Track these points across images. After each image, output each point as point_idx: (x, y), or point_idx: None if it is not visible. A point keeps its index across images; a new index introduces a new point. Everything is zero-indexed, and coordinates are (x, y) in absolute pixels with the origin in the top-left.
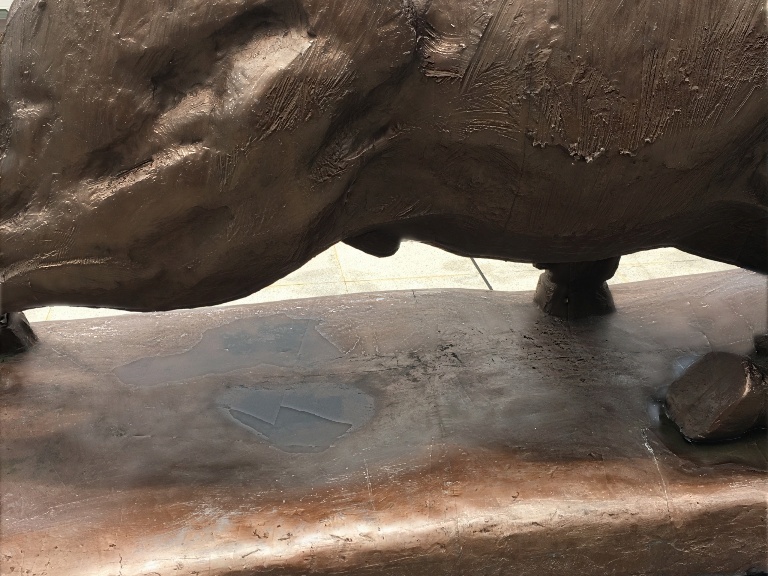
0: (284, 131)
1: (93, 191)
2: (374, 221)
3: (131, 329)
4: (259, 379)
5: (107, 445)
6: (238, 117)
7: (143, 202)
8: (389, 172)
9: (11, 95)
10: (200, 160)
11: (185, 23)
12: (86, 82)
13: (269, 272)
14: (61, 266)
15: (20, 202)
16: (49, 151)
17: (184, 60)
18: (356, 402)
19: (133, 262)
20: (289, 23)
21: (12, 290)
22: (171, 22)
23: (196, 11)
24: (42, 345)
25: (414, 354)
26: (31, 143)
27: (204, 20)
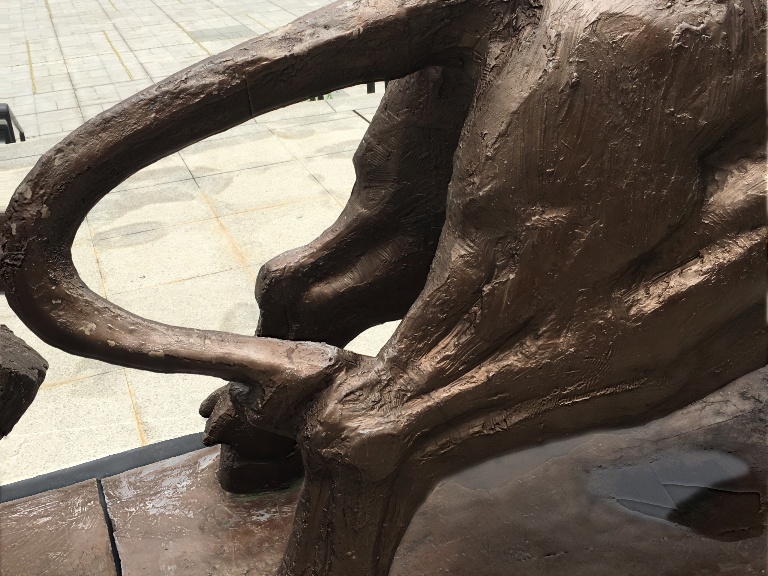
0: None
1: (631, 304)
2: None
3: None
4: (611, 455)
5: (526, 575)
6: None
7: (696, 308)
8: None
9: (522, 200)
10: (766, 249)
11: (749, 87)
12: (635, 174)
13: None
14: (589, 399)
15: (526, 328)
16: (577, 263)
17: (736, 131)
18: (736, 463)
19: (667, 378)
20: None
21: (516, 435)
22: (732, 88)
23: (761, 71)
24: None
25: (746, 394)
26: (554, 257)
27: None
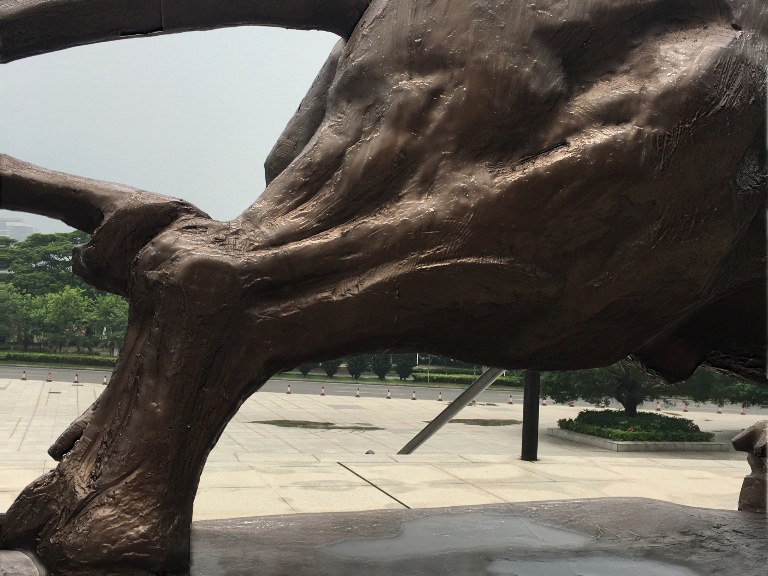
0: (732, 110)
1: (495, 174)
2: (757, 274)
3: (301, 520)
4: (522, 553)
5: None
6: (684, 88)
7: (563, 185)
8: (766, 220)
9: (391, 68)
10: (632, 140)
11: (605, 3)
12: (498, 48)
13: (669, 312)
14: (449, 265)
15: (388, 192)
16: (441, 126)
17: (597, 44)
18: (669, 570)
19: (537, 268)
20: (706, 19)
21: (367, 304)
22: (590, 1)
23: None
24: (196, 531)
25: (687, 532)
26: (418, 117)
27: (625, 2)
